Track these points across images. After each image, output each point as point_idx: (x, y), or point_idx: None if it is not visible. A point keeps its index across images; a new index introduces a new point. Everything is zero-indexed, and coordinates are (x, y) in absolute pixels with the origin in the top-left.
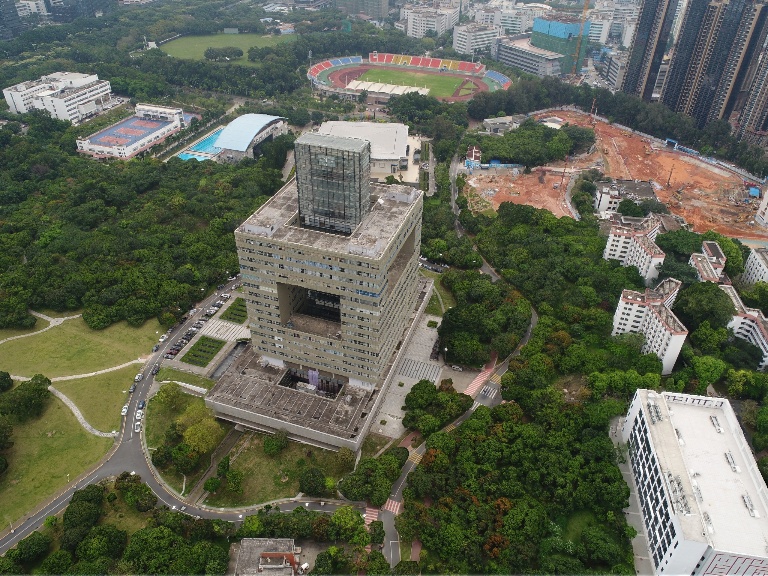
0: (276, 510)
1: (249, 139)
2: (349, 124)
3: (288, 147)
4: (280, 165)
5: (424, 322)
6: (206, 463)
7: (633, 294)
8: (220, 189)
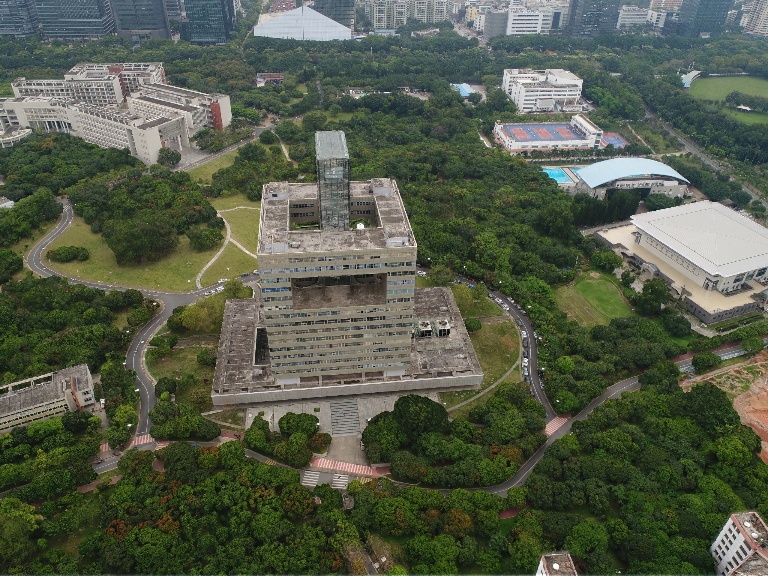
0: (133, 378)
1: (607, 179)
2: (733, 216)
3: (655, 209)
4: (604, 216)
5: None
6: (186, 335)
7: (569, 570)
8: (500, 200)
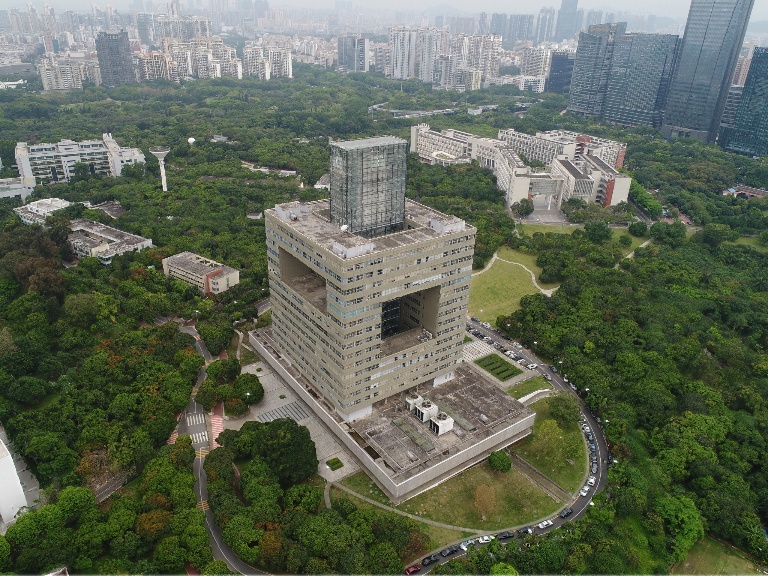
0: None
1: None
2: None
3: None
4: None
5: (346, 460)
6: None
7: None
8: None
